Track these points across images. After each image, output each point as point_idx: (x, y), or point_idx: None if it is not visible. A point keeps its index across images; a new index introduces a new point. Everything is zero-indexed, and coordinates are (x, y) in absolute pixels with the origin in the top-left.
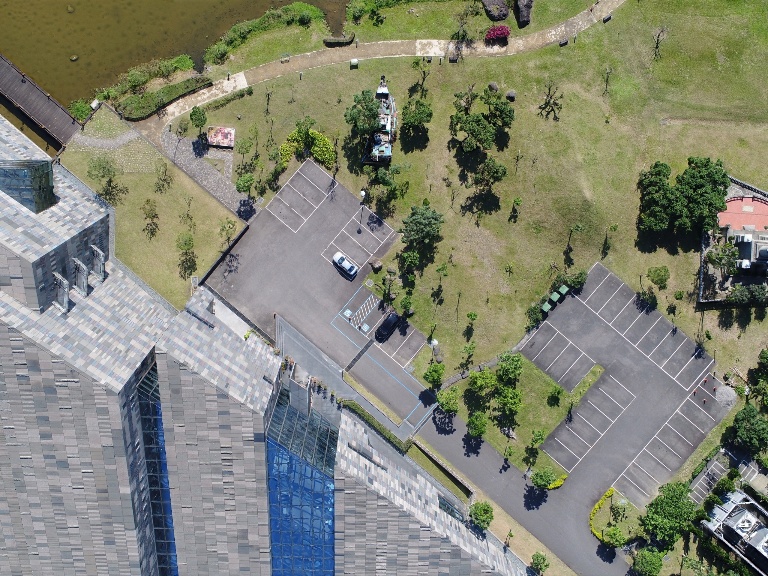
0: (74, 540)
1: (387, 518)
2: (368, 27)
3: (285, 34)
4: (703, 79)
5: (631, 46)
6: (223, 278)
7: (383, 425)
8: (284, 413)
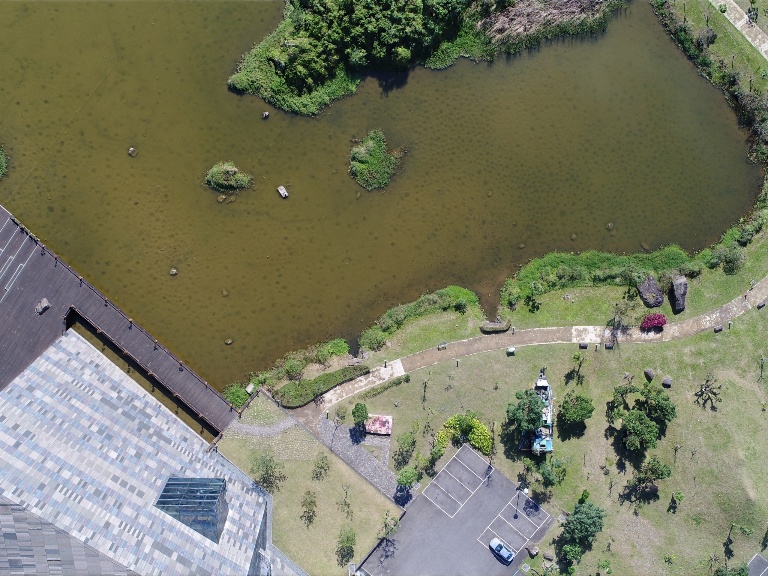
0: None
1: None
2: (524, 313)
3: (441, 320)
4: None
5: None
6: (379, 563)
7: None
8: None
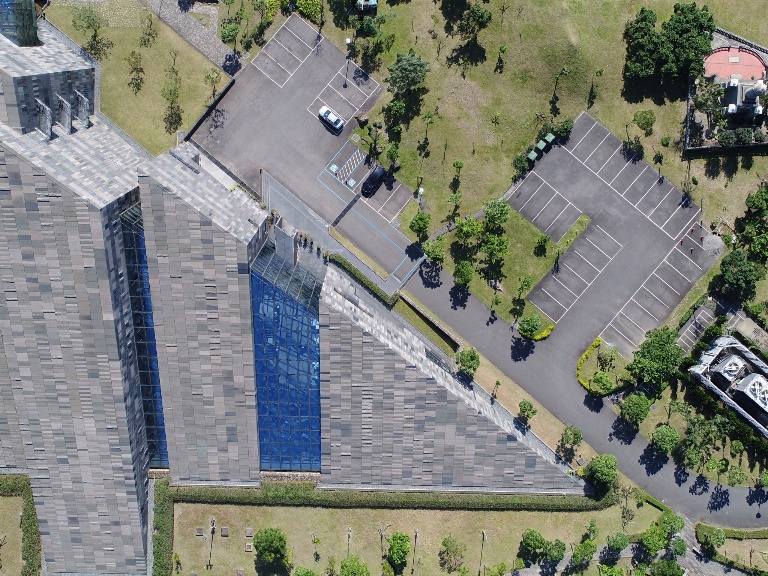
0: (58, 372)
1: (372, 357)
2: None
3: None
4: None
5: None
6: (209, 133)
7: (370, 279)
8: (269, 258)
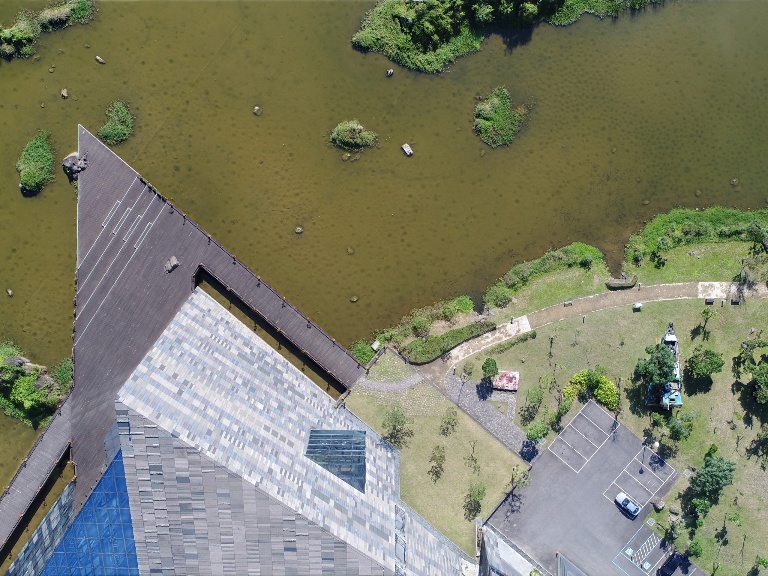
0: None
1: None
2: (650, 269)
3: (567, 277)
4: None
5: None
6: (505, 518)
7: None
8: None
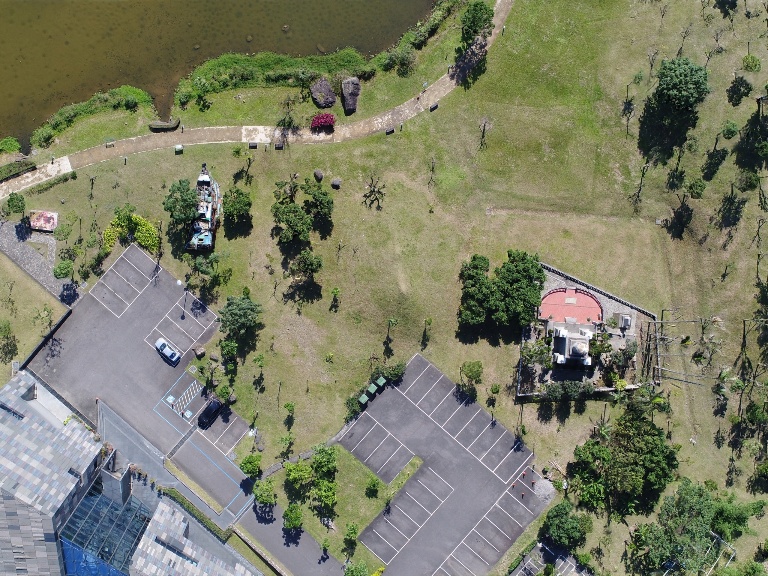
0: None
1: None
2: (194, 112)
3: (111, 118)
4: (529, 169)
5: (457, 135)
6: (45, 362)
7: (203, 513)
8: (92, 505)
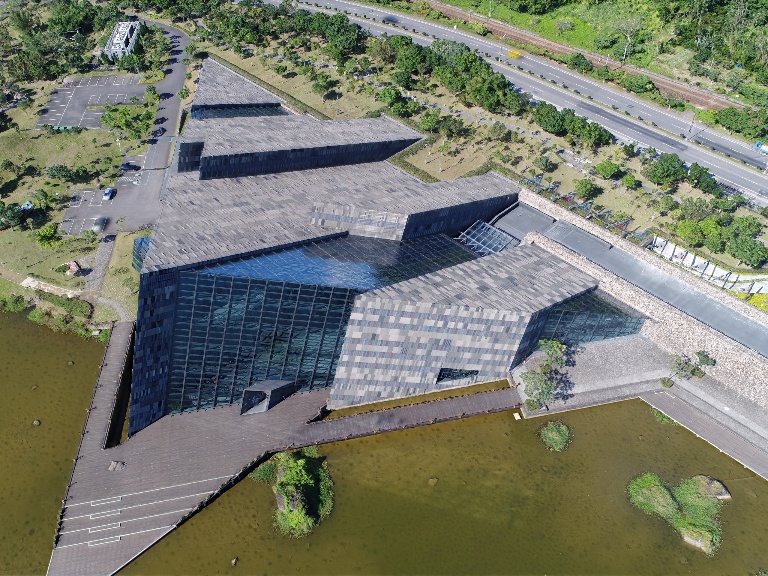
0: None
1: None
2: None
3: None
4: None
5: None
6: None
7: None
8: None
